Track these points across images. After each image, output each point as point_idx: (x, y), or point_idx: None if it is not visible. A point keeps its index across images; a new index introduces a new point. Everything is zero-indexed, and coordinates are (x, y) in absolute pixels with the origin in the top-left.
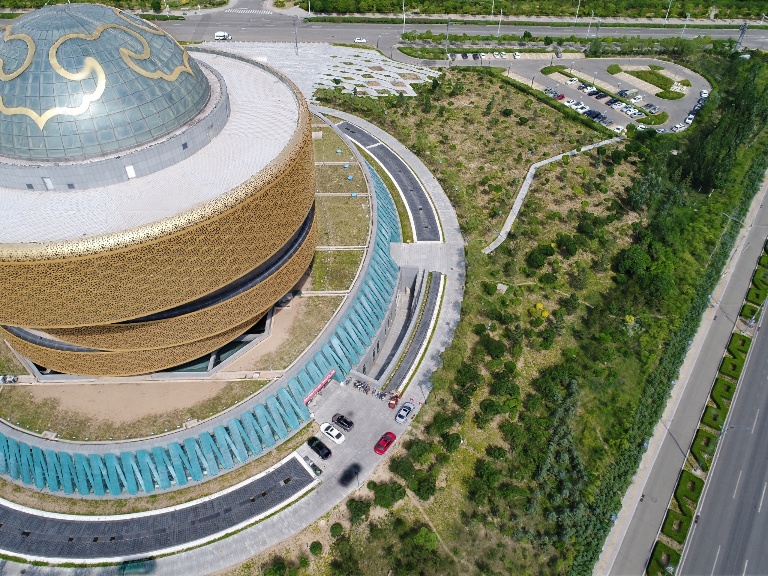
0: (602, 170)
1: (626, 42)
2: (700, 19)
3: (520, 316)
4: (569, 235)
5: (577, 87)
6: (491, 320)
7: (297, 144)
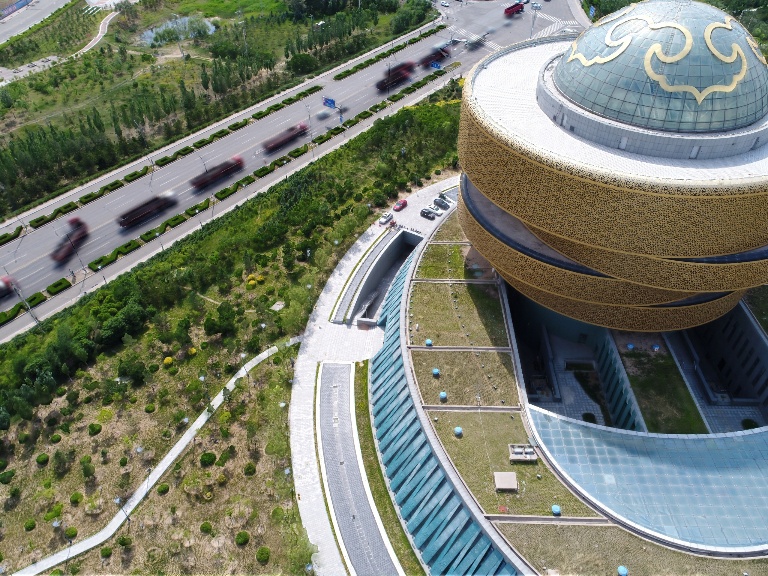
0: None
1: None
2: None
3: None
4: None
5: None
6: None
7: None
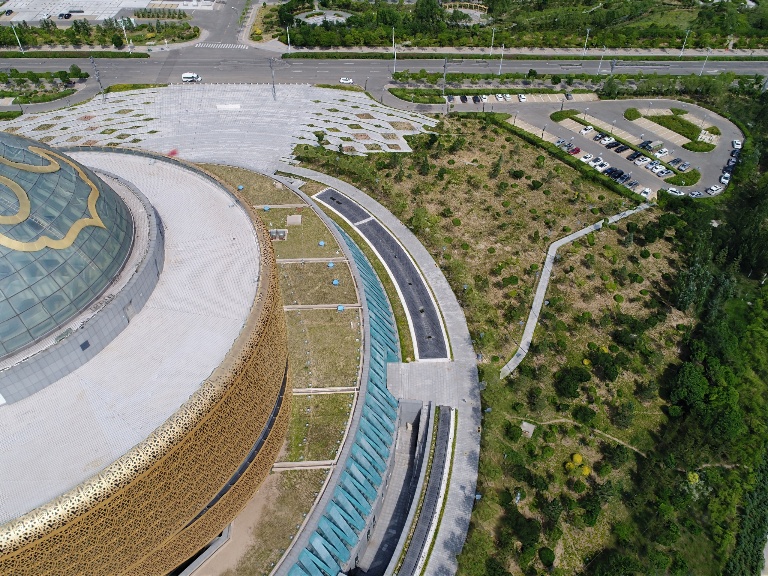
0: (633, 250)
1: (644, 82)
2: (718, 49)
3: (555, 479)
4: (607, 353)
5: (593, 137)
6: (517, 481)
7: (254, 330)
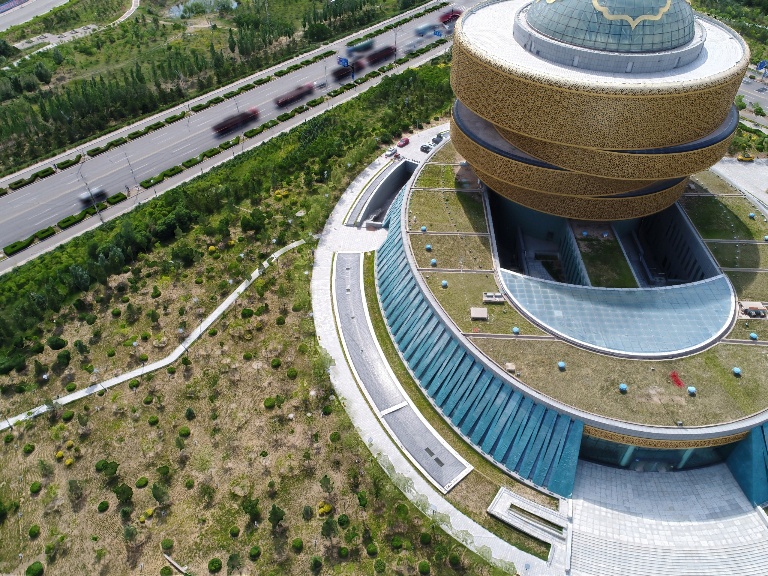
0: None
1: None
2: None
3: None
4: None
5: None
6: None
7: None
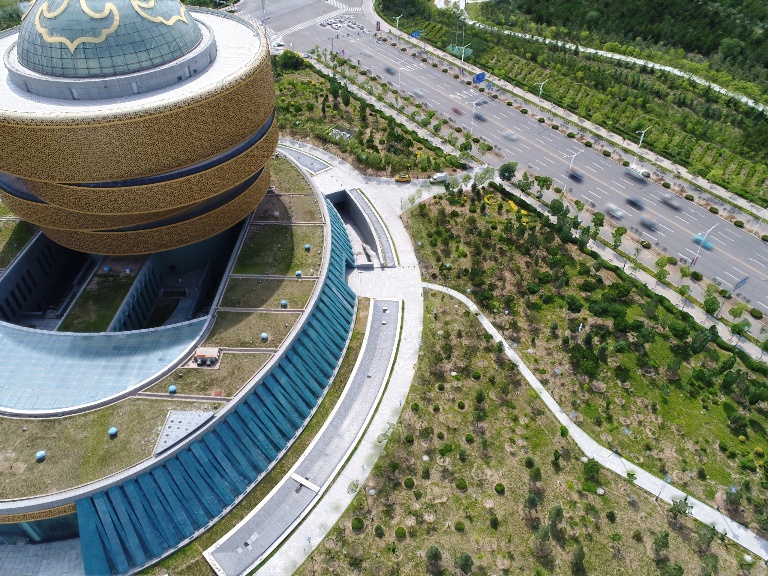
0: None
1: None
2: None
3: None
4: None
5: None
6: None
7: None
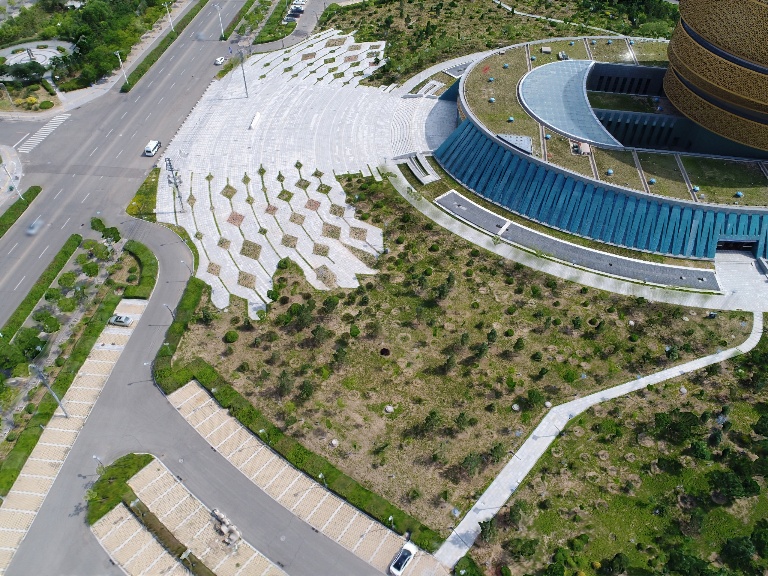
0: None
1: None
2: None
3: None
4: None
5: None
6: None
7: None
